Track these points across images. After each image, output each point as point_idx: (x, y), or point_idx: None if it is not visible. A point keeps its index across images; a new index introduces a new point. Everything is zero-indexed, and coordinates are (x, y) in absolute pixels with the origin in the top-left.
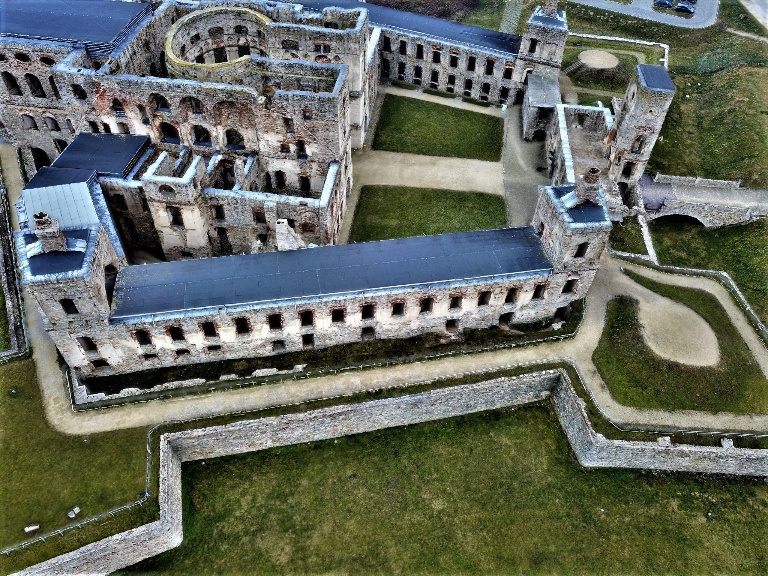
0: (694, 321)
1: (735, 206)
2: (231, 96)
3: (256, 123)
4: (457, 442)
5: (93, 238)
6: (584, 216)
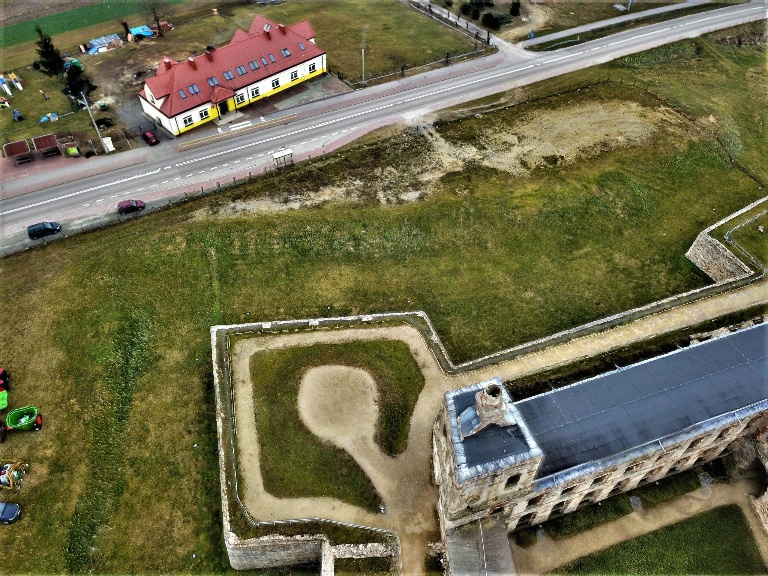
0: (316, 417)
1: None
2: None
3: None
4: (527, 337)
5: None
6: None
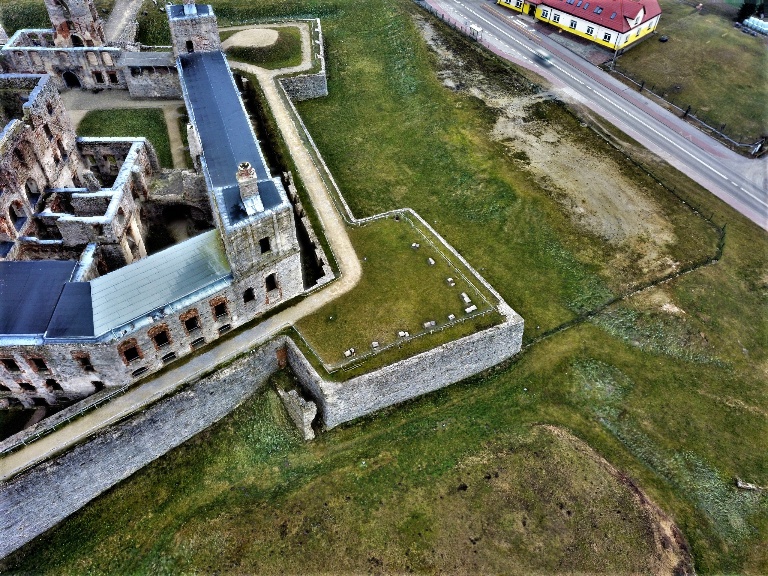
0: (247, 32)
1: (124, 26)
2: (13, 141)
3: (36, 153)
4: (320, 134)
5: (234, 185)
6: (205, 9)
